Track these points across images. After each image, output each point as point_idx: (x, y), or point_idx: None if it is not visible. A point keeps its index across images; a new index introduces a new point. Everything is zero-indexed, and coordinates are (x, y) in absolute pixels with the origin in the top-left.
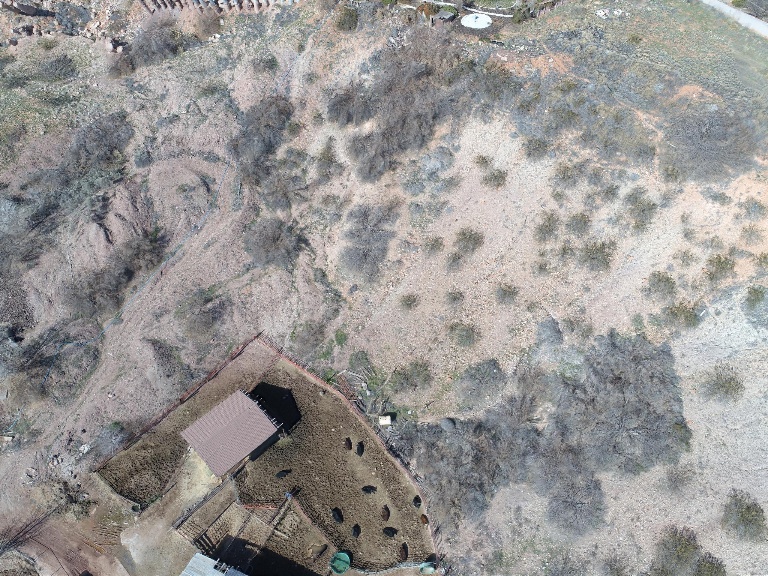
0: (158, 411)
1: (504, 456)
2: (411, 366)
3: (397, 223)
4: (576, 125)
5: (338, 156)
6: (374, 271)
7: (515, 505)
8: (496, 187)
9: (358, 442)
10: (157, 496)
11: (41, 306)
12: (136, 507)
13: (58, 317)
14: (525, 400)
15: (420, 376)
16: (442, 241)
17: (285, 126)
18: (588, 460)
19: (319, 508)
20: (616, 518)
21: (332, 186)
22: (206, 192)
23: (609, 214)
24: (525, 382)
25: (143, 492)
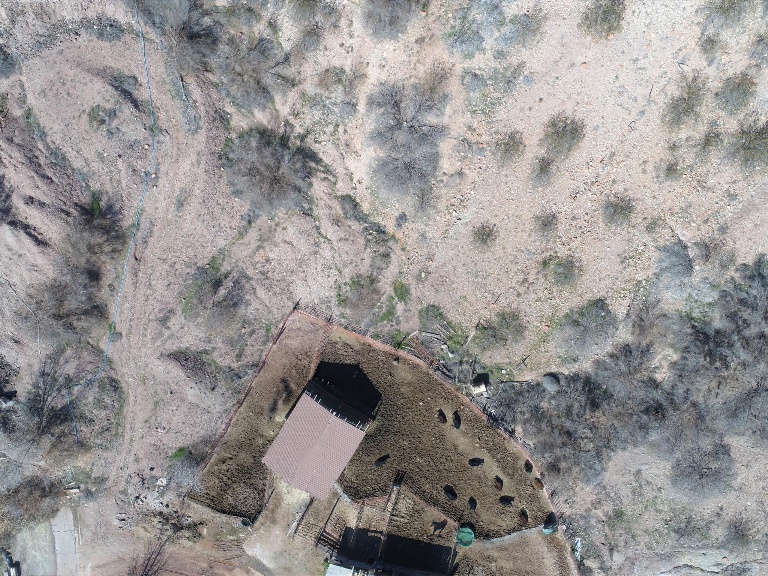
0: (219, 425)
1: (620, 418)
2: (497, 318)
3: (447, 111)
4: None
5: None
6: (425, 191)
7: (635, 469)
8: (605, 34)
9: (452, 413)
10: (261, 506)
11: (9, 350)
12: (245, 521)
13: (40, 356)
14: (641, 347)
15: (510, 328)
16: (521, 138)
17: None
18: (716, 420)
19: (429, 488)
20: (746, 485)
21: (328, 51)
22: (135, 111)
23: None
24: (644, 333)
25: (245, 505)
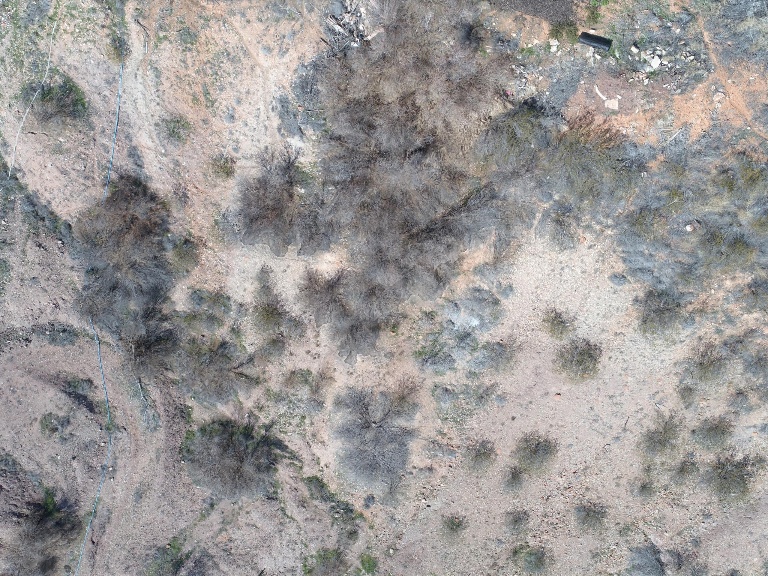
0: None
1: None
2: None
3: (417, 417)
4: (745, 263)
5: (288, 303)
6: (394, 480)
7: None
8: (581, 374)
9: None
10: None
11: None
12: None
13: None
14: None
15: None
16: (492, 447)
17: (166, 249)
18: None
19: None
20: None
21: (293, 357)
22: (90, 415)
23: (766, 419)
24: None
25: None
